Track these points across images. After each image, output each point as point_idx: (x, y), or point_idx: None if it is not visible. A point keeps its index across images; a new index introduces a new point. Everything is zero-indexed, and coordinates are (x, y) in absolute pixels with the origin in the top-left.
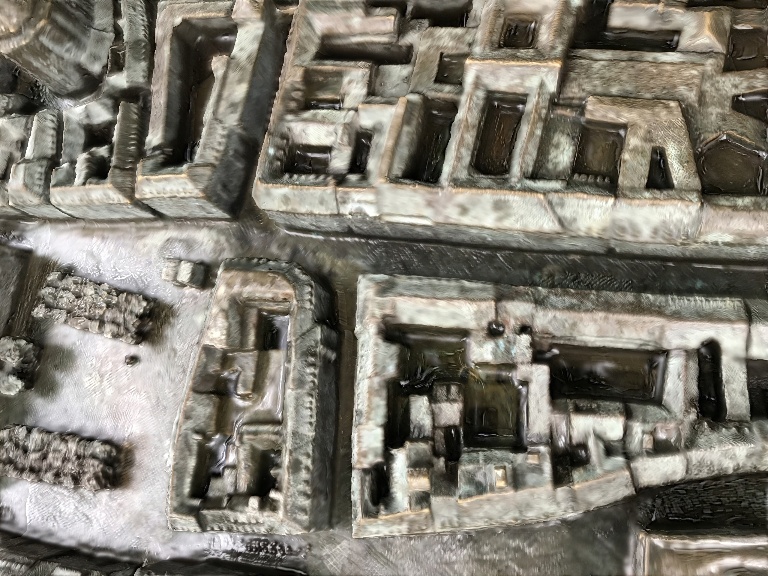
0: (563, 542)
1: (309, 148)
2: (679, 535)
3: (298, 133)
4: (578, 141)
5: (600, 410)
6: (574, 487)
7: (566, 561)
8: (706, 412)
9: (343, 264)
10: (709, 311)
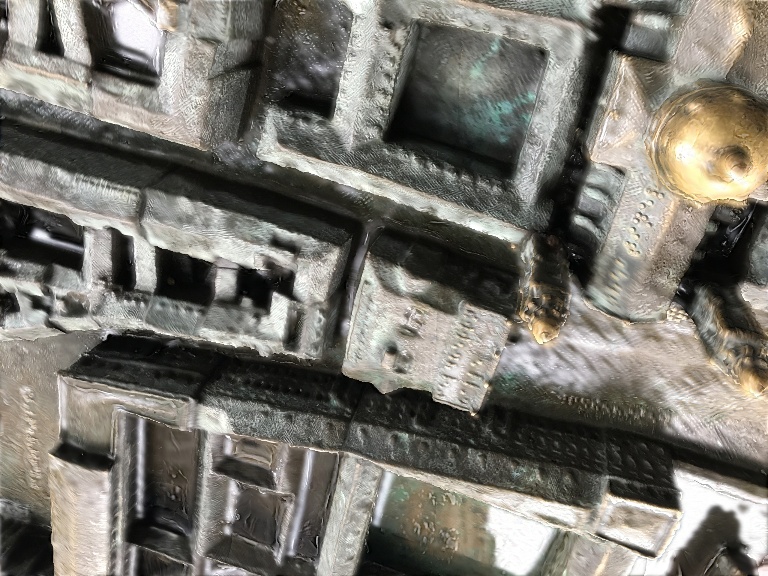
0: (53, 338)
1: None
2: (83, 376)
3: None
4: None
5: (20, 272)
6: (4, 330)
7: (56, 351)
8: (124, 277)
9: None
10: (105, 201)
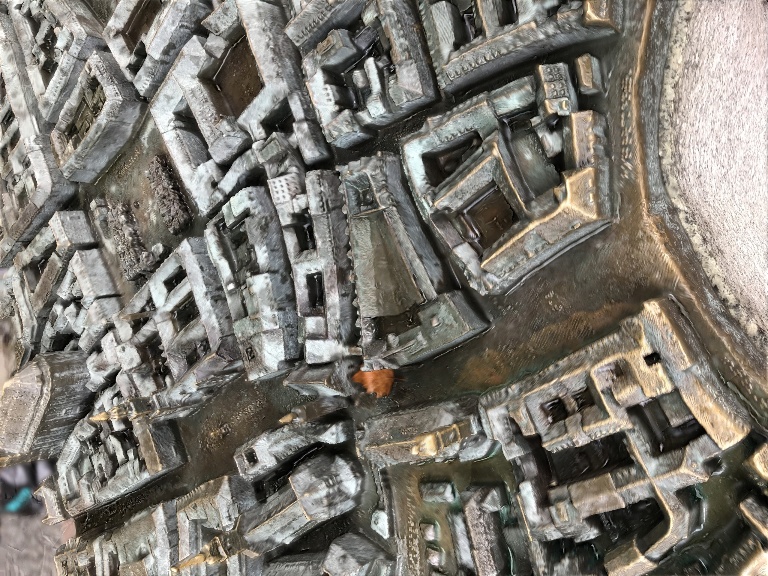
0: None
1: (36, 186)
2: None
3: (32, 193)
4: (4, 96)
5: None
6: None
7: None
8: None
9: None
10: None
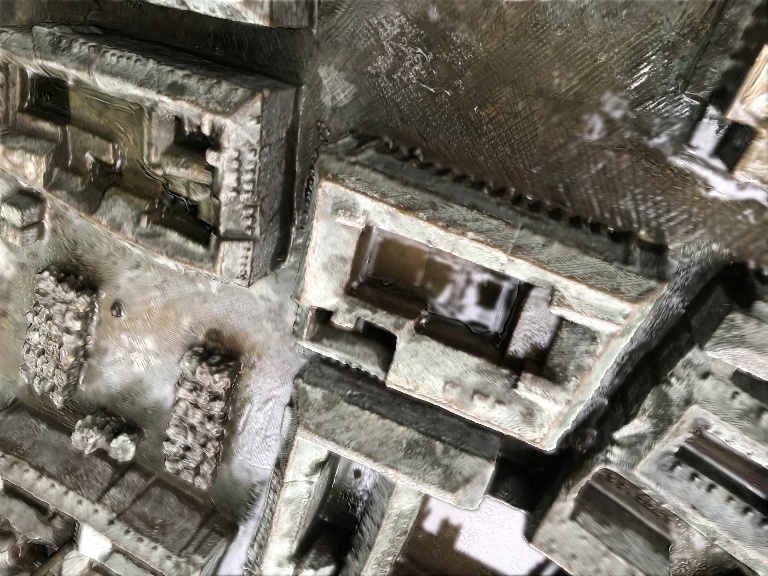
0: None
1: None
2: None
3: None
4: None
5: None
6: None
7: None
8: None
9: (19, 8)
10: None
